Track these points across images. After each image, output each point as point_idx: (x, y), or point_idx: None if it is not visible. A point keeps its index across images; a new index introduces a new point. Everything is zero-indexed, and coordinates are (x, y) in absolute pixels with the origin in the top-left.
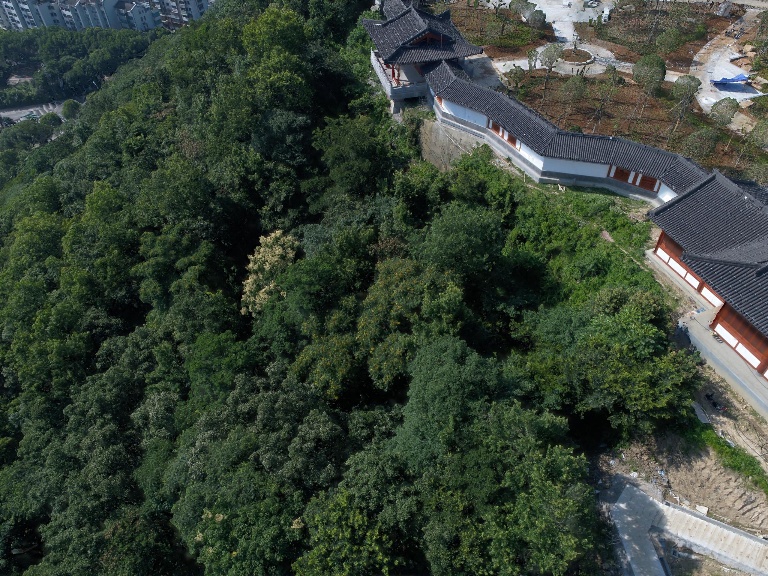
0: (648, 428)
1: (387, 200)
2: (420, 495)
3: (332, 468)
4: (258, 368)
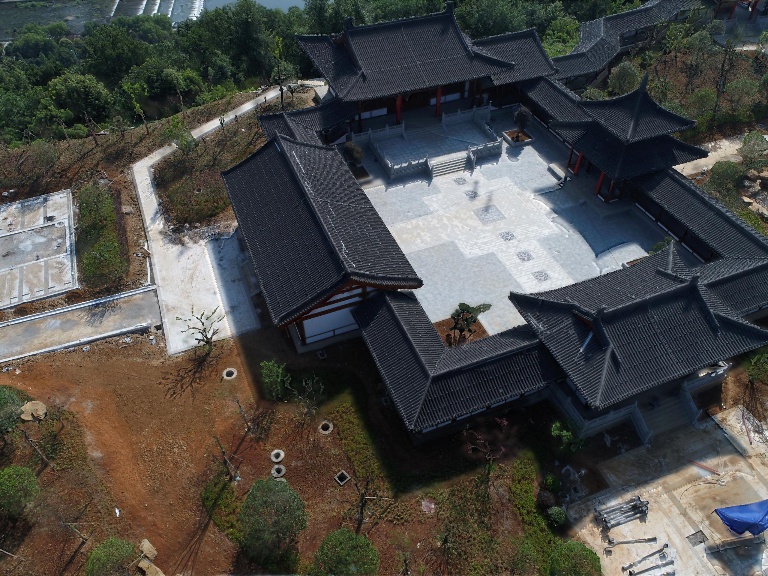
0: None
1: (536, 7)
2: None
3: None
4: None
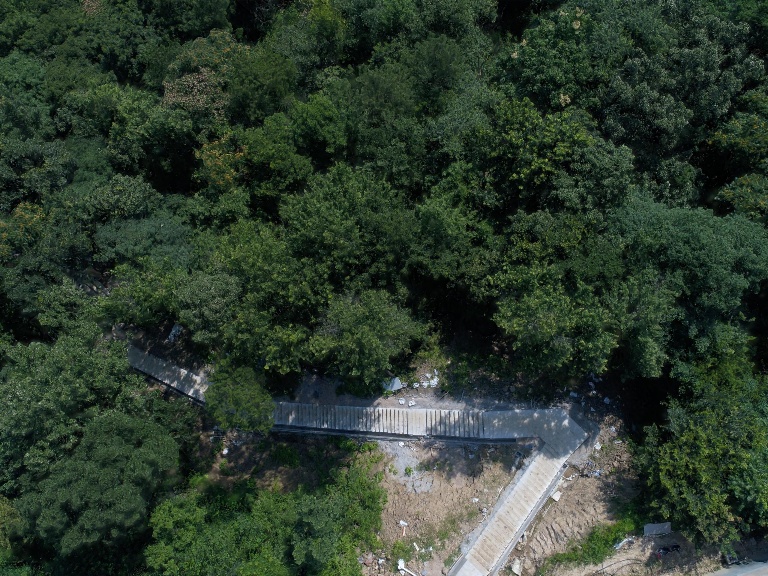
0: (640, 462)
1: None
2: (583, 214)
3: (621, 134)
4: (762, 54)
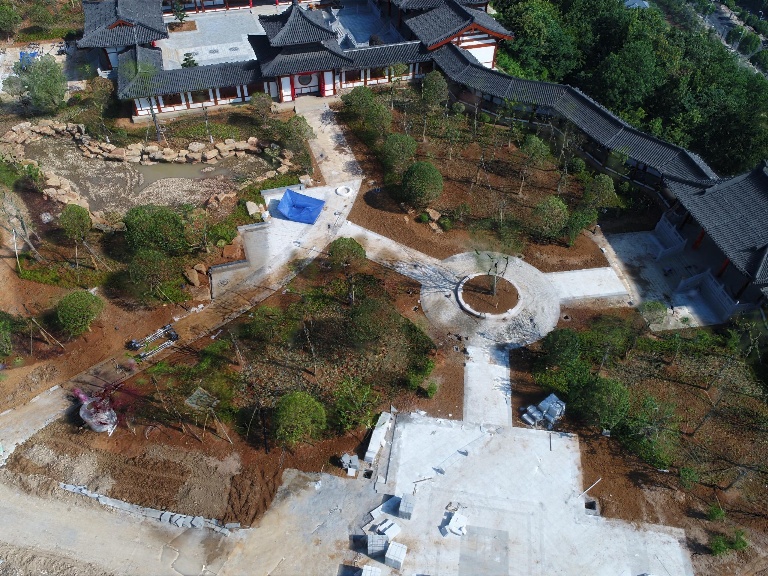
0: None
1: None
2: None
3: None
4: None
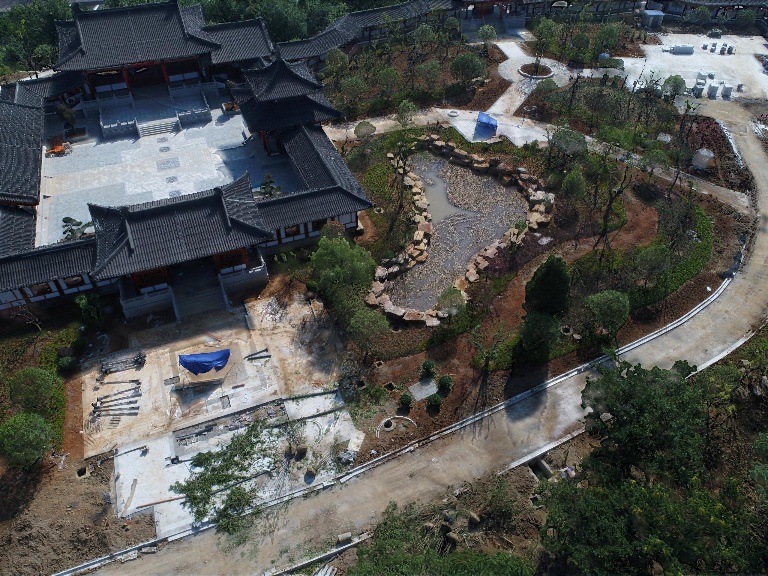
0: None
1: (326, 8)
2: None
3: None
4: None
